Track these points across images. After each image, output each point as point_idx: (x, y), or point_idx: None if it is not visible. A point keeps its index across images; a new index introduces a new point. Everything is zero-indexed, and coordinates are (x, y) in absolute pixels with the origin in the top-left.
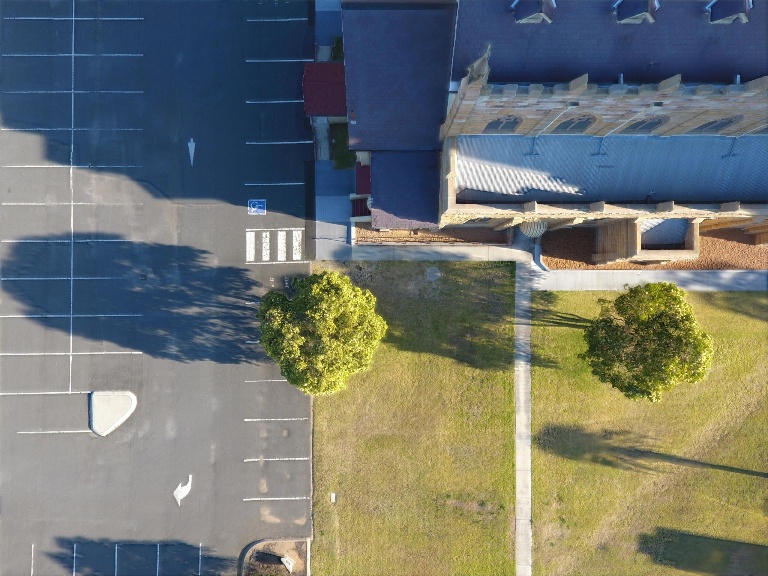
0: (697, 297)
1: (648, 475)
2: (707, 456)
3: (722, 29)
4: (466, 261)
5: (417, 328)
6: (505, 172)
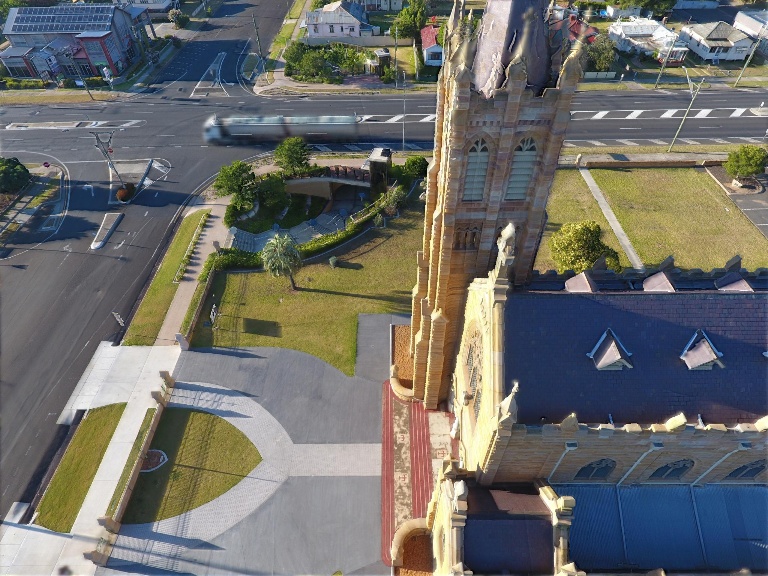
0: None
1: None
2: None
3: None
4: None
5: None
6: None
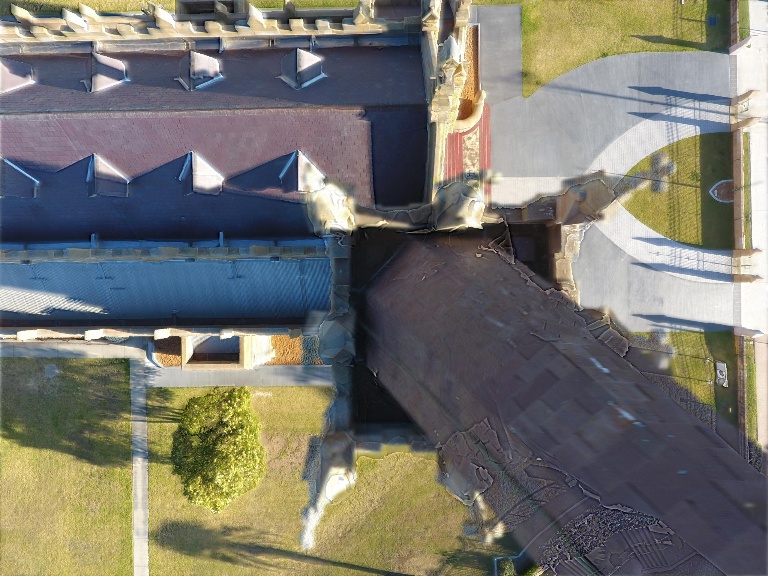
0: (317, 392)
1: (269, 571)
2: (329, 553)
3: (32, 199)
4: (82, 358)
5: (37, 424)
6: (20, 294)
